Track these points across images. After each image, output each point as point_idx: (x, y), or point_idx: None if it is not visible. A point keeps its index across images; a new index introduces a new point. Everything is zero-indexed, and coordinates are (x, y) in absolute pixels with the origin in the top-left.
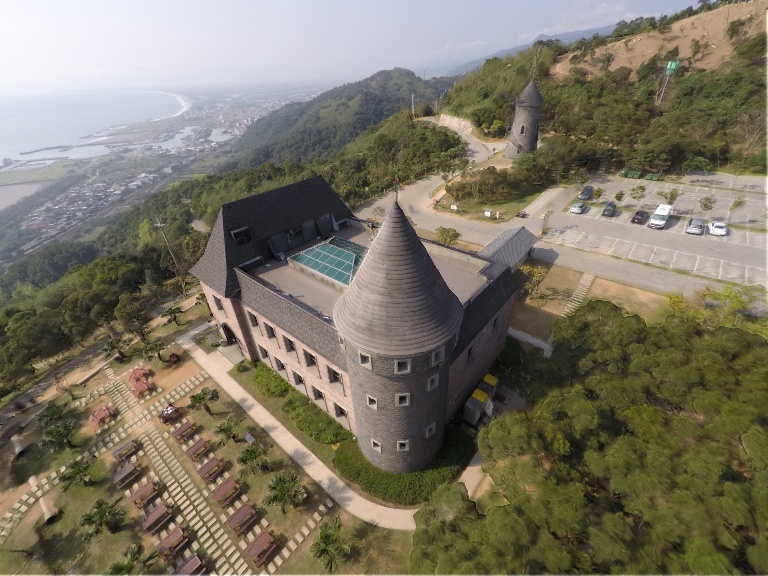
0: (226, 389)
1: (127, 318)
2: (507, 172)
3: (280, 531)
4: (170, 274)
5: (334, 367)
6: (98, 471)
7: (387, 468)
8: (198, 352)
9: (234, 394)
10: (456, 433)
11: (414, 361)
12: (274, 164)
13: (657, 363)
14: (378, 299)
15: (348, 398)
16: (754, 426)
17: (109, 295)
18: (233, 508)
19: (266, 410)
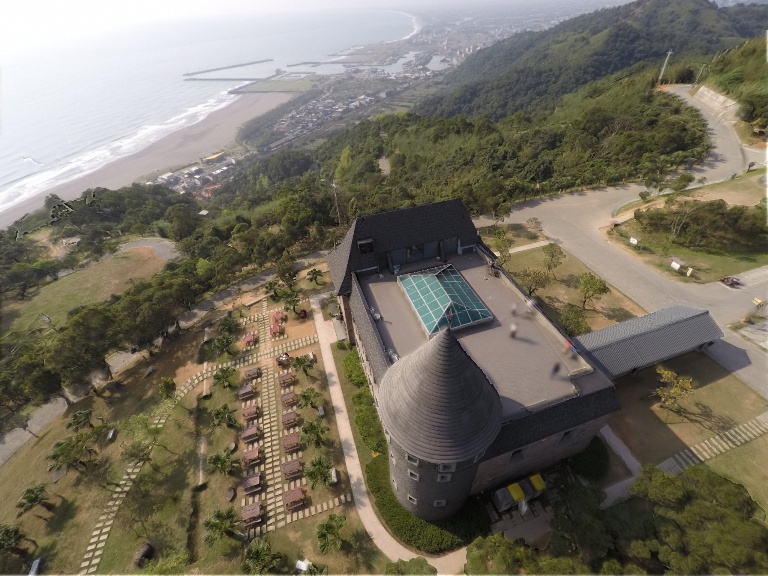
0: (324, 358)
1: (282, 272)
2: (744, 213)
3: (310, 494)
4: (336, 223)
5: None
6: (235, 379)
7: (400, 501)
8: (319, 316)
9: (327, 366)
10: (477, 509)
11: (422, 461)
12: (467, 118)
13: None
14: (408, 398)
15: None
16: None
17: (283, 241)
18: (291, 457)
19: (342, 392)
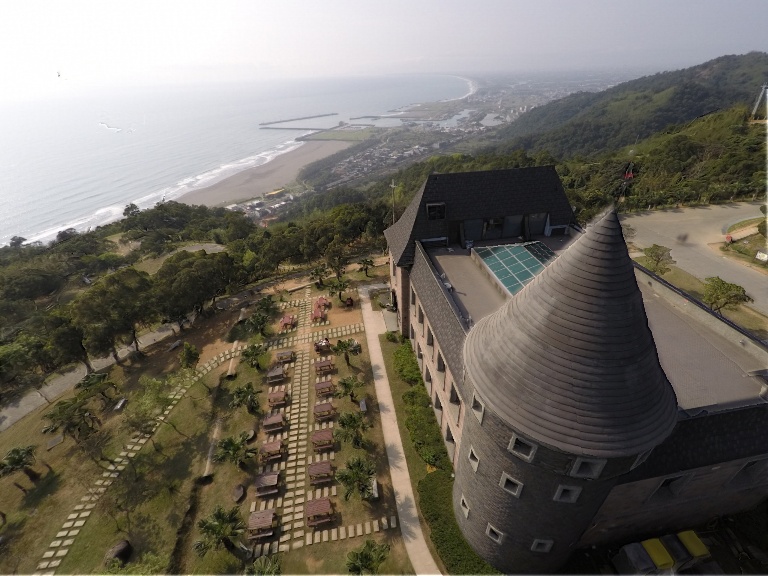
0: (370, 349)
1: (332, 255)
2: None
3: (341, 510)
4: None
5: (457, 388)
6: (265, 361)
7: (469, 539)
8: (367, 305)
9: (373, 357)
10: (588, 571)
11: (542, 451)
12: (527, 153)
13: None
14: (524, 340)
15: (460, 431)
16: None
17: (334, 232)
18: (320, 457)
19: (390, 388)
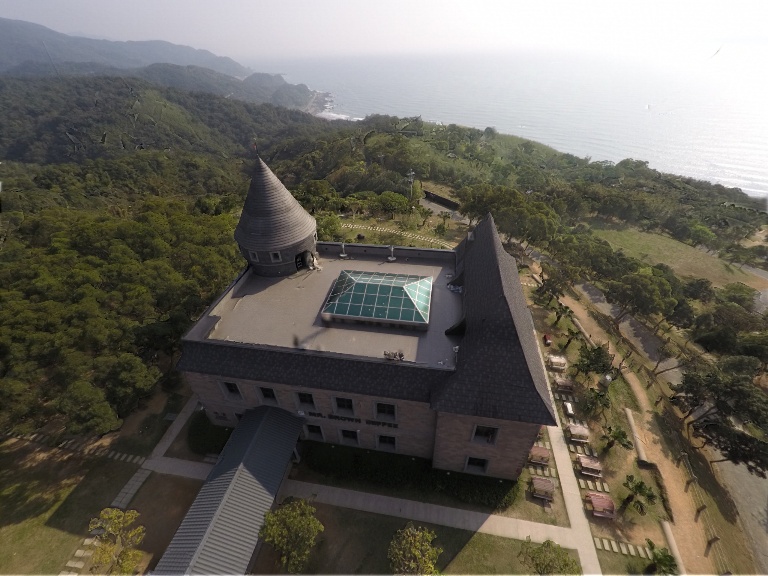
0: None
1: (545, 269)
2: None
3: None
4: None
5: None
6: None
7: None
8: None
9: None
10: None
11: None
12: None
13: (97, 317)
14: None
15: None
16: (83, 286)
17: (642, 293)
18: None
19: None
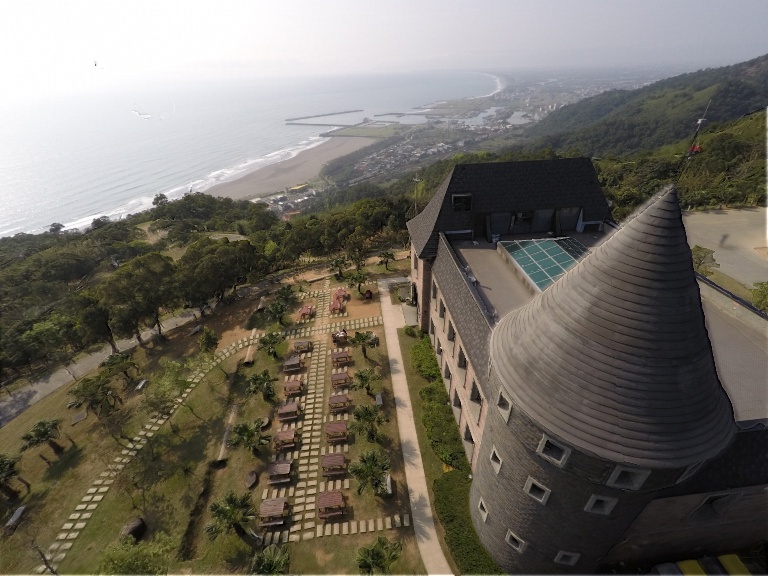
0: (388, 343)
1: (352, 246)
2: None
3: (353, 504)
4: None
5: (479, 386)
6: (282, 350)
7: (486, 544)
8: (387, 299)
9: (391, 351)
10: None
11: (576, 456)
12: (556, 151)
13: None
14: (561, 334)
15: (480, 430)
16: None
17: (356, 225)
18: (334, 449)
19: (407, 383)
